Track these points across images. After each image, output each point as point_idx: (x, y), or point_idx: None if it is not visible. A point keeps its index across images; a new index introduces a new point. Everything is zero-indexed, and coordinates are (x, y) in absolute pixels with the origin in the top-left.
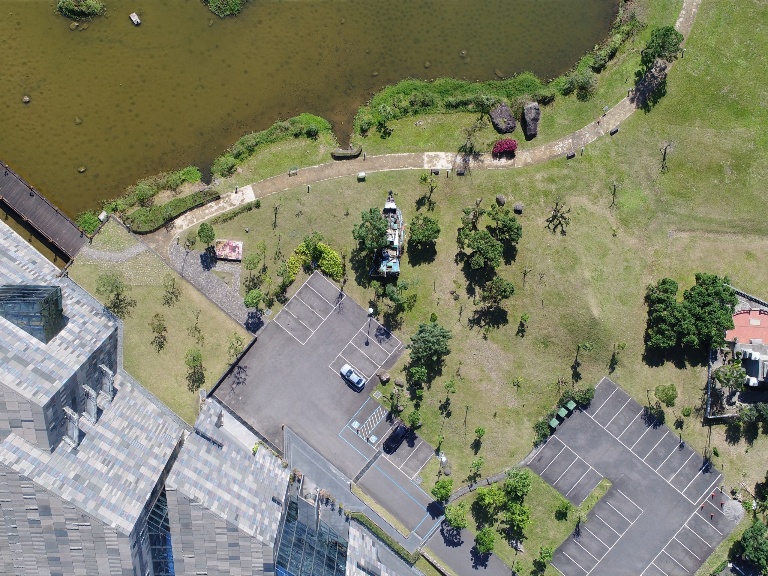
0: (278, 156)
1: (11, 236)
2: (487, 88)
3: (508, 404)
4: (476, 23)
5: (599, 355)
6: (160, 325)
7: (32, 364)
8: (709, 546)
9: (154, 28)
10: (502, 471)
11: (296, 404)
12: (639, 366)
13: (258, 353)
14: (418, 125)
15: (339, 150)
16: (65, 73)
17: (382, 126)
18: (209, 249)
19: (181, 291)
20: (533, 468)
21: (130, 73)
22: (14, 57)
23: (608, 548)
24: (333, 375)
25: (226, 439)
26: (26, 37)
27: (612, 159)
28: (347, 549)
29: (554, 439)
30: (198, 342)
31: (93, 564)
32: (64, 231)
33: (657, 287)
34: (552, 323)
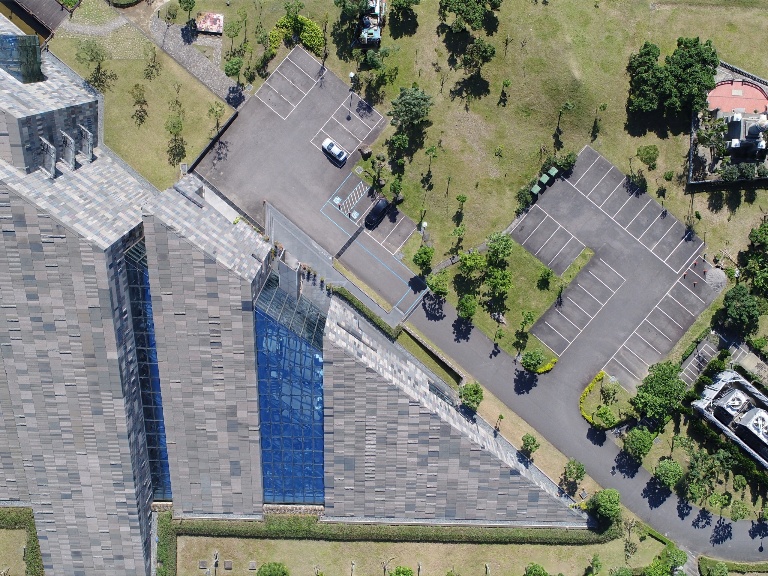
0: None
1: None
2: None
3: (490, 174)
4: None
5: (581, 121)
6: (140, 95)
7: (8, 90)
8: (692, 315)
9: None
10: (484, 242)
11: (277, 180)
12: (621, 135)
13: (239, 128)
14: None
15: None
16: None
17: None
18: (190, 22)
19: (162, 65)
20: (515, 238)
21: None
22: None
23: (590, 317)
24: (315, 150)
25: (206, 204)
26: None
27: None
28: (328, 311)
29: (536, 208)
30: (179, 116)
31: (69, 284)
32: (44, 4)
33: (639, 54)
34: (534, 90)
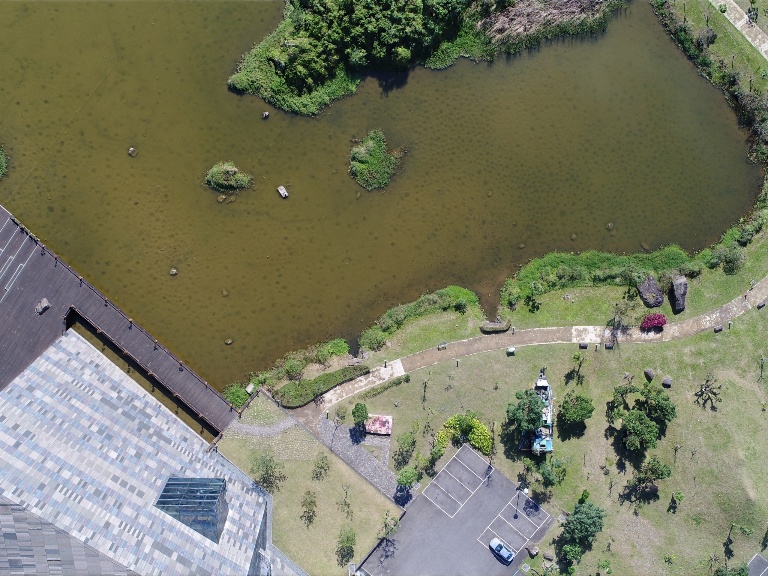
0: (427, 330)
1: (160, 411)
2: (634, 261)
3: None
4: (622, 196)
5: (752, 533)
6: (312, 502)
7: (213, 574)
8: None
9: (301, 201)
10: None
11: None
12: None
13: (406, 526)
14: (566, 299)
15: (487, 324)
16: (212, 245)
17: (530, 299)
18: (358, 423)
19: (330, 465)
20: None
21: (277, 245)
22: (161, 229)
23: None
24: (481, 548)
25: None
26: (173, 209)
27: (759, 333)
28: None
29: None
30: (347, 516)
31: None
32: (213, 405)
33: None
34: (705, 501)
